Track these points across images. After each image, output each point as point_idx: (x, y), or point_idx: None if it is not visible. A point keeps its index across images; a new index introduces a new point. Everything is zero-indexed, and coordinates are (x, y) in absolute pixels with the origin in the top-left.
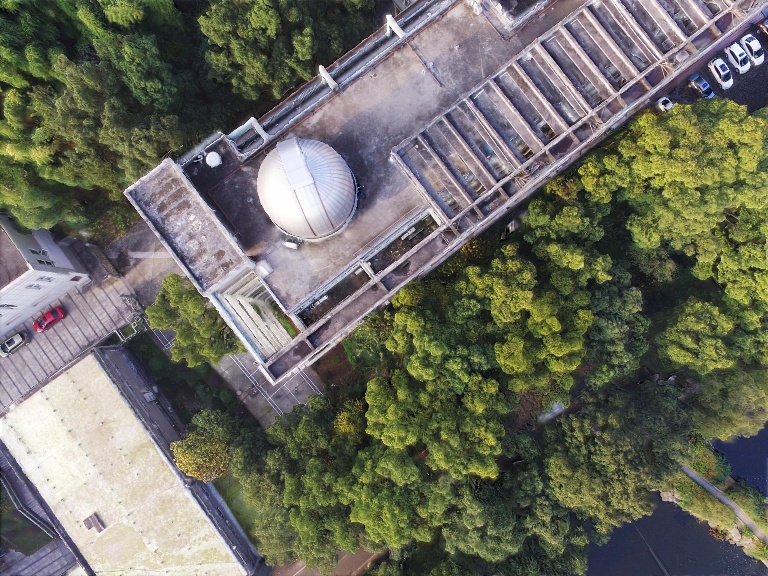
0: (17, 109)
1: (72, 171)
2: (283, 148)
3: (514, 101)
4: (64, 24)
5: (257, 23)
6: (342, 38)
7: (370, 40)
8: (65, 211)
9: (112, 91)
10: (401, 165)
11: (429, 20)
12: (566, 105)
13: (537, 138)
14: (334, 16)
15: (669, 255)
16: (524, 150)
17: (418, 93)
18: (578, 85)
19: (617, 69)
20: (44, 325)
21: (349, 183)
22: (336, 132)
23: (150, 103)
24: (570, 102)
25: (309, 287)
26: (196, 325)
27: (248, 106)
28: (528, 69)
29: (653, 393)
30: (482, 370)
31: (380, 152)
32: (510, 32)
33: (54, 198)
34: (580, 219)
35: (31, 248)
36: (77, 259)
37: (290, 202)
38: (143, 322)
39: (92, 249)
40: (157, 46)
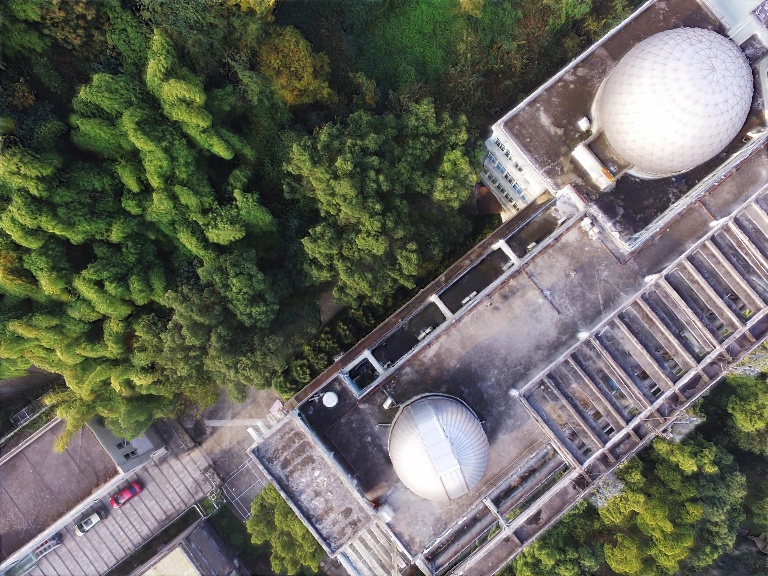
0: (118, 336)
1: (173, 393)
2: (424, 427)
3: (639, 337)
4: (161, 240)
5: (365, 246)
6: (442, 242)
7: (475, 252)
8: (155, 411)
9: (218, 319)
10: (527, 408)
11: (544, 246)
12: (691, 338)
13: (666, 377)
14: (430, 215)
15: (767, 429)
16: (651, 386)
17: (535, 321)
18: (703, 318)
19: (742, 300)
20: (121, 502)
21: (487, 451)
22: (453, 365)
23: (253, 323)
24: (696, 336)
25: (432, 529)
26: (300, 540)
27: (333, 286)
28: (652, 303)
29: (754, 566)
30: (592, 572)
31: (499, 384)
32: (626, 255)
33: (148, 408)
34: (685, 411)
35: (116, 442)
36: (152, 430)
37: (435, 486)
38: (222, 493)
39: (170, 424)
40: (256, 260)
